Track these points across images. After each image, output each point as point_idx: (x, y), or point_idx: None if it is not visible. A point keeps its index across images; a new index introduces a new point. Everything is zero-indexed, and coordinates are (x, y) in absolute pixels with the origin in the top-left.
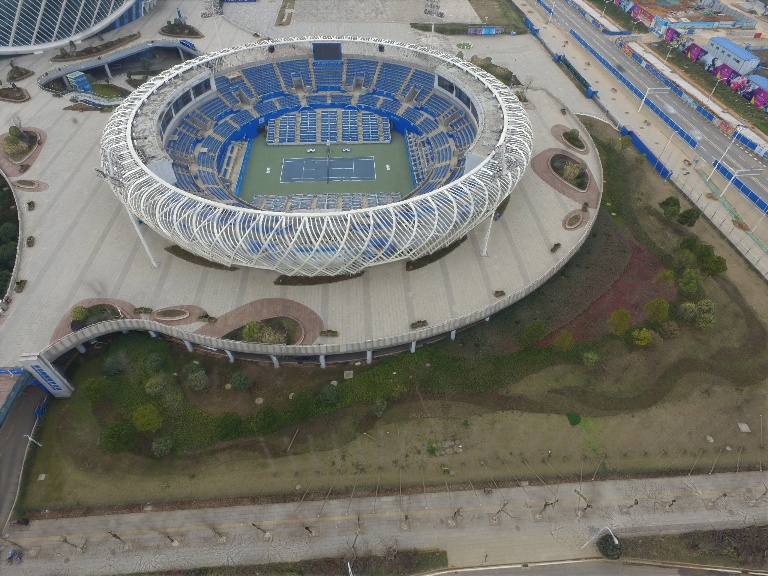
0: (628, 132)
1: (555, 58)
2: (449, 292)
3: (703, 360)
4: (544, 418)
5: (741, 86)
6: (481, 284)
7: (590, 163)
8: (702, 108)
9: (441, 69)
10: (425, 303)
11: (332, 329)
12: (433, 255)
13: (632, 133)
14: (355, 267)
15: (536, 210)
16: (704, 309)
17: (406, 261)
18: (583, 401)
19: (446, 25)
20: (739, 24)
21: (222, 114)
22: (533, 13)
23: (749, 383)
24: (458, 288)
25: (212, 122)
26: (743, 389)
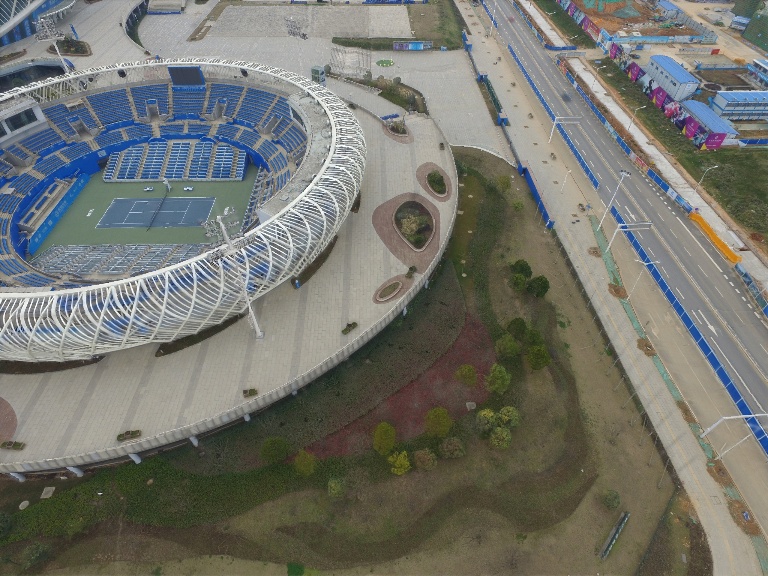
0: (523, 169)
1: (478, 78)
2: (191, 388)
3: (488, 490)
4: (258, 568)
5: (674, 113)
6: (235, 378)
7: (444, 213)
8: (621, 139)
9: (292, 99)
10: (154, 403)
11: (21, 438)
12: (197, 335)
13: (526, 170)
14: (79, 355)
15: (351, 275)
16: (504, 420)
17: (161, 343)
18: (314, 546)
19: (372, 40)
20: (697, 39)
21: (51, 147)
22: (477, 25)
23: (537, 527)
24: (205, 383)
25: (34, 157)
26: (527, 536)
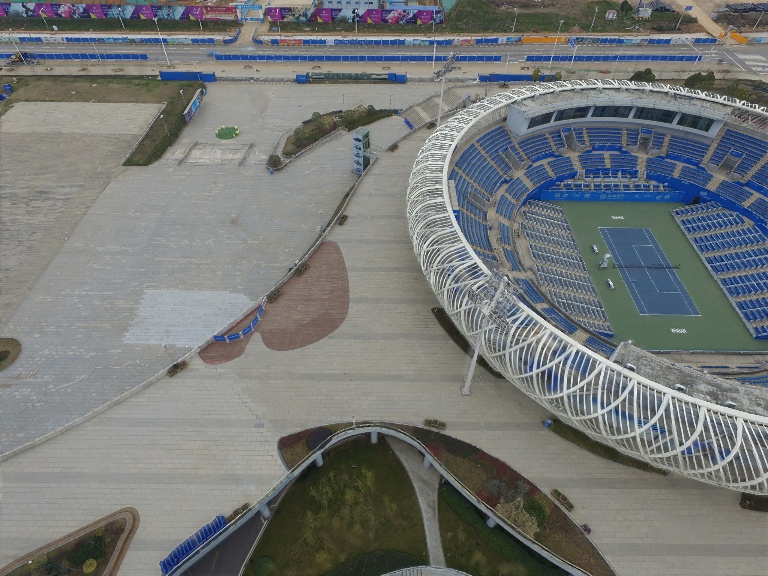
0: None
1: (301, 80)
2: None
3: None
4: None
5: (400, 17)
6: None
7: None
8: (436, 41)
9: (532, 110)
10: None
11: None
12: None
13: (491, 76)
14: None
15: None
16: None
17: None
18: None
19: (152, 134)
20: None
21: None
22: (125, 69)
23: None
24: None
25: None
26: None
